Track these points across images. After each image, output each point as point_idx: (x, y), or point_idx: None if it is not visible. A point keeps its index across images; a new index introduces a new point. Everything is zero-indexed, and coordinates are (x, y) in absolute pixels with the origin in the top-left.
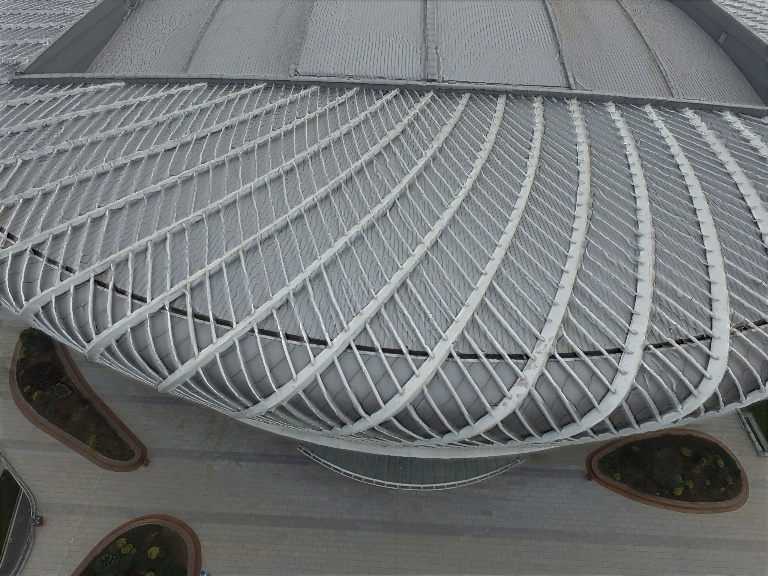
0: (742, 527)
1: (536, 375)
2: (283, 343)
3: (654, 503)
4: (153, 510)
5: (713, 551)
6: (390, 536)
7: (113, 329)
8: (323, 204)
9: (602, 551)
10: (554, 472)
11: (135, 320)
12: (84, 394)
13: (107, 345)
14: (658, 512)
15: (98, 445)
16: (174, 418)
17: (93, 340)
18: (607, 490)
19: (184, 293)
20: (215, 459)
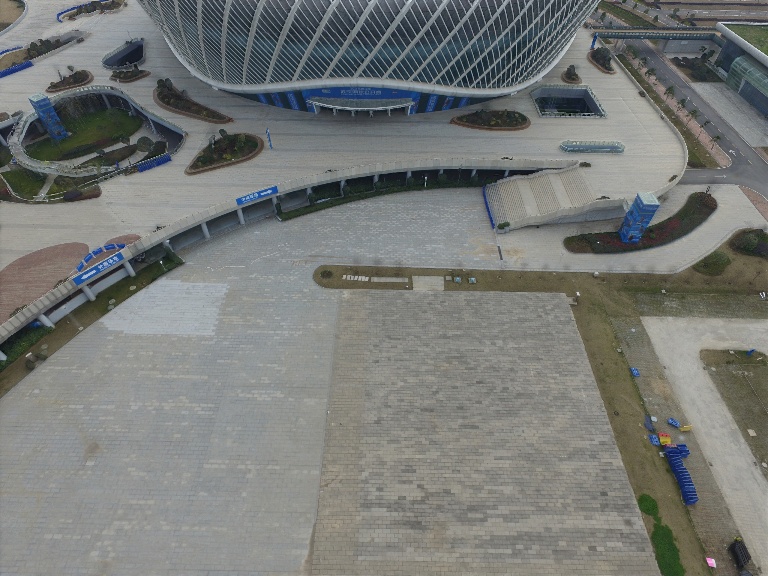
0: (521, 134)
1: None
2: None
3: (481, 128)
4: (239, 132)
5: None
6: (352, 137)
7: None
8: None
9: (451, 140)
10: (434, 122)
11: None
12: (195, 103)
13: None
14: (482, 131)
15: (208, 114)
16: (243, 110)
17: None
18: (459, 126)
19: None
20: (266, 120)
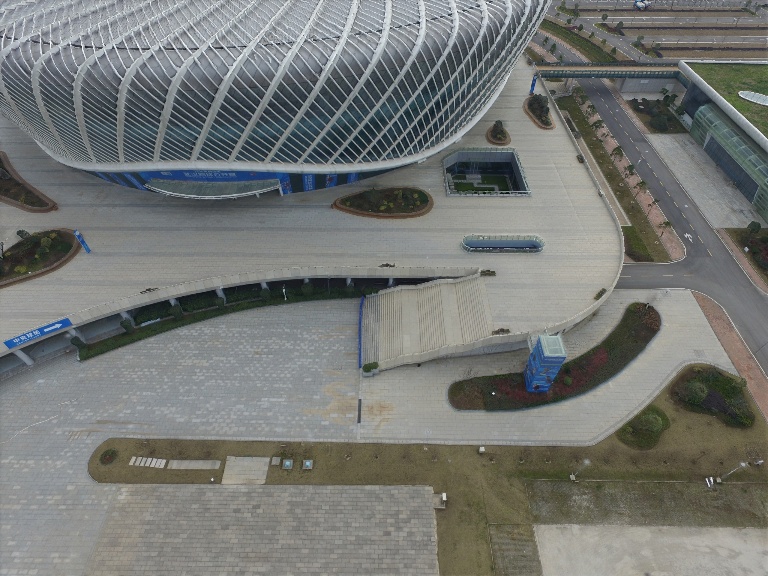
0: (417, 223)
1: (198, 53)
2: (82, 47)
3: (367, 215)
4: (57, 227)
5: (393, 232)
6: (199, 232)
7: (3, 49)
8: (118, 1)
9: (325, 234)
10: (311, 206)
11: (14, 45)
12: (20, 182)
13: (2, 62)
14: (368, 219)
15: (26, 200)
16: (77, 191)
17: None
18: (341, 212)
19: (39, 34)
20: (99, 207)
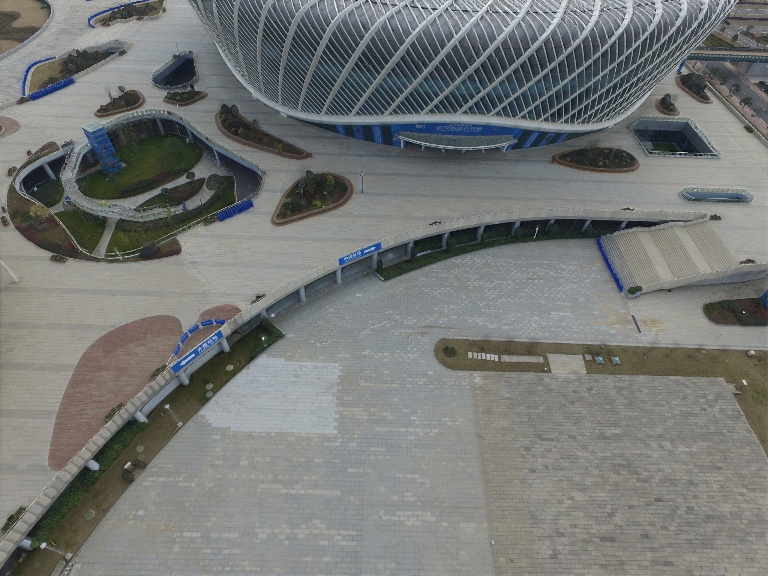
0: (633, 177)
1: (522, 16)
2: (420, 8)
3: (588, 170)
4: (321, 171)
5: (617, 184)
6: (448, 179)
7: (348, 7)
8: None
9: (559, 184)
10: (534, 161)
11: (357, 4)
12: (266, 133)
13: (342, 18)
14: (589, 173)
15: (283, 148)
16: (320, 143)
17: (336, 17)
18: (563, 166)
19: None
20: (348, 156)
